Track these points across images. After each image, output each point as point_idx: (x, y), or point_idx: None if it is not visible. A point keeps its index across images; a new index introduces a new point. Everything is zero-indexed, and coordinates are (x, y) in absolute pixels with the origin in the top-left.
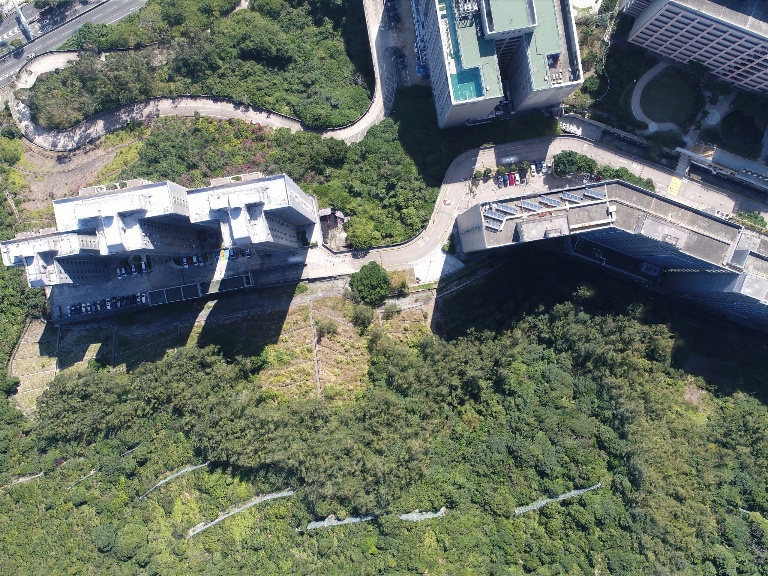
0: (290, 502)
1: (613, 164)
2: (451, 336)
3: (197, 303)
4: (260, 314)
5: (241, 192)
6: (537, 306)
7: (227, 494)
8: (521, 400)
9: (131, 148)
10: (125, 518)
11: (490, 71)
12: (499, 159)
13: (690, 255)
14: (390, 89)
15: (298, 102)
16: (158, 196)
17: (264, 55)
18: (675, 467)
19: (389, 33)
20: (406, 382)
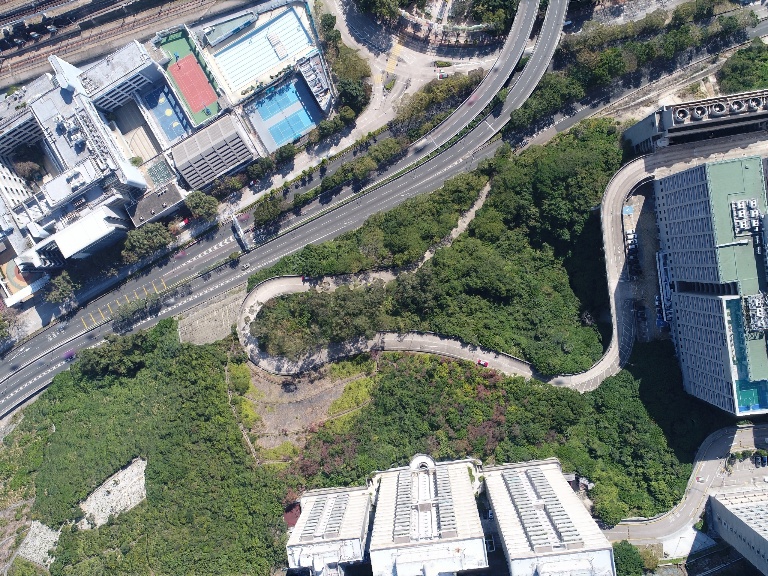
0: None
1: None
2: None
3: None
4: None
5: (573, 571)
6: None
7: None
8: None
9: (360, 385)
10: None
11: None
12: (757, 438)
13: None
14: (627, 340)
15: (529, 345)
16: (473, 549)
17: (493, 294)
18: None
19: (629, 285)
20: None
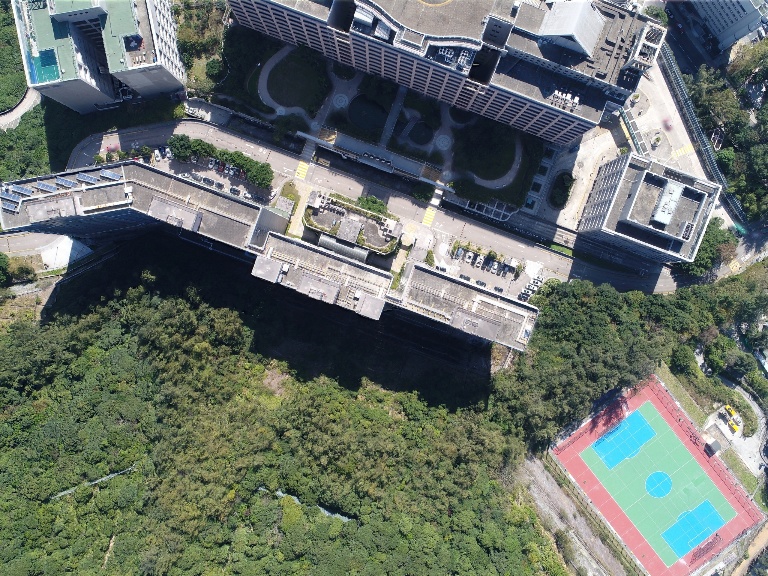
0: None
1: (239, 149)
2: None
3: None
4: None
5: None
6: None
7: None
8: (84, 384)
9: None
10: None
11: (65, 53)
12: (124, 144)
13: (208, 236)
14: None
15: None
16: None
17: None
18: (214, 451)
19: None
20: None
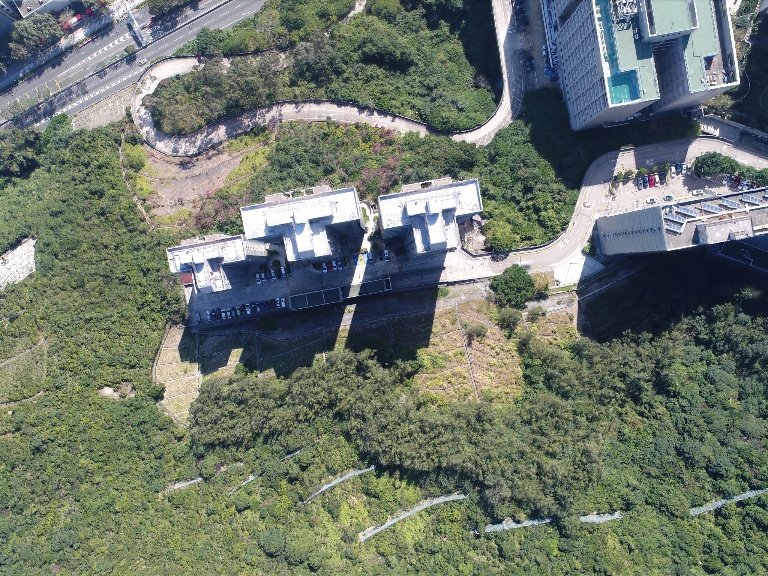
0: (463, 505)
1: (752, 165)
2: (601, 338)
3: (337, 307)
4: (406, 318)
5: (438, 198)
6: (695, 307)
7: (397, 498)
8: (686, 401)
9: (258, 153)
10: (290, 523)
11: (647, 74)
12: (639, 161)
13: None
14: (518, 92)
15: (424, 105)
16: (344, 202)
17: (388, 59)
18: None
19: (517, 36)
20: (568, 384)
